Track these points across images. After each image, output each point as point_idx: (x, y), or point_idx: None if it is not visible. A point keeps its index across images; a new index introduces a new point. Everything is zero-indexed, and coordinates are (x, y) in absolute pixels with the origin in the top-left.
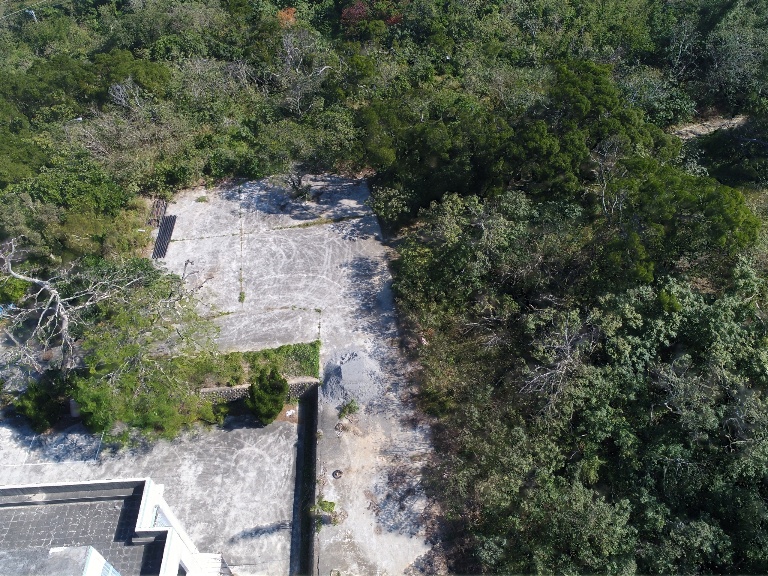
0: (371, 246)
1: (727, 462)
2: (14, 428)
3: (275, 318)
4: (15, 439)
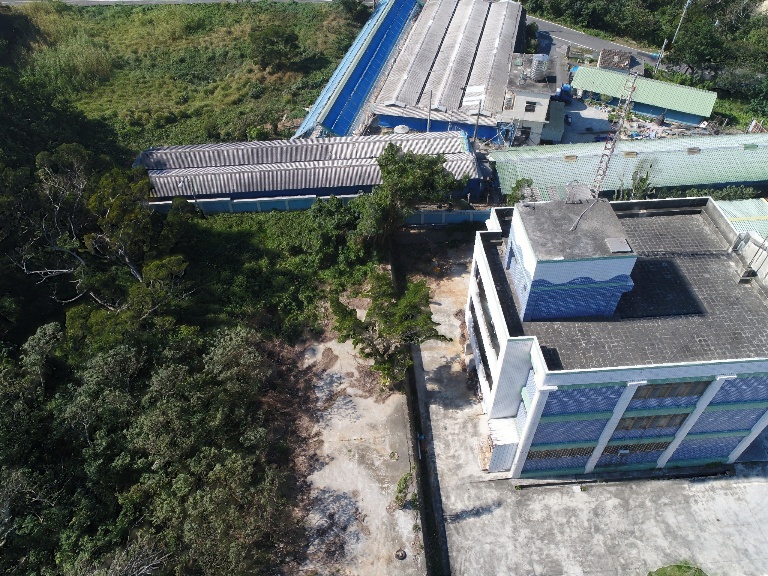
0: None
1: None
2: None
3: None
4: None
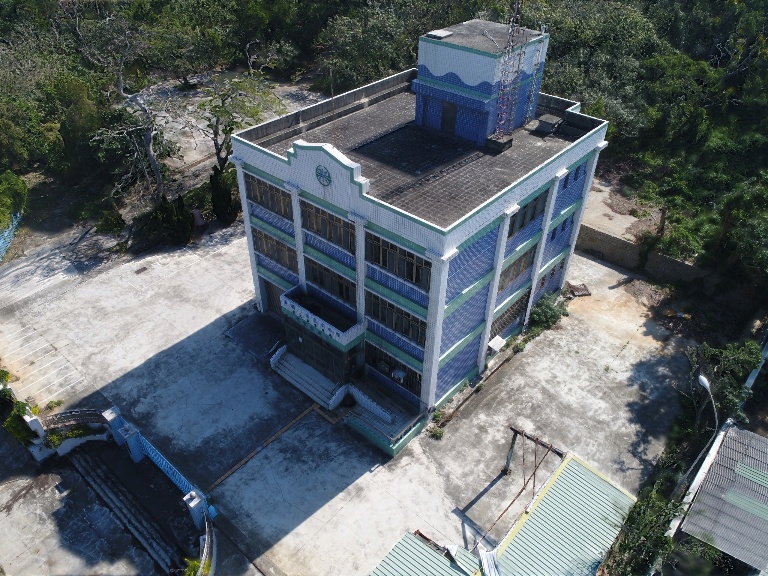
0: (283, 89)
1: (575, 53)
2: (157, 253)
3: None
4: (169, 256)
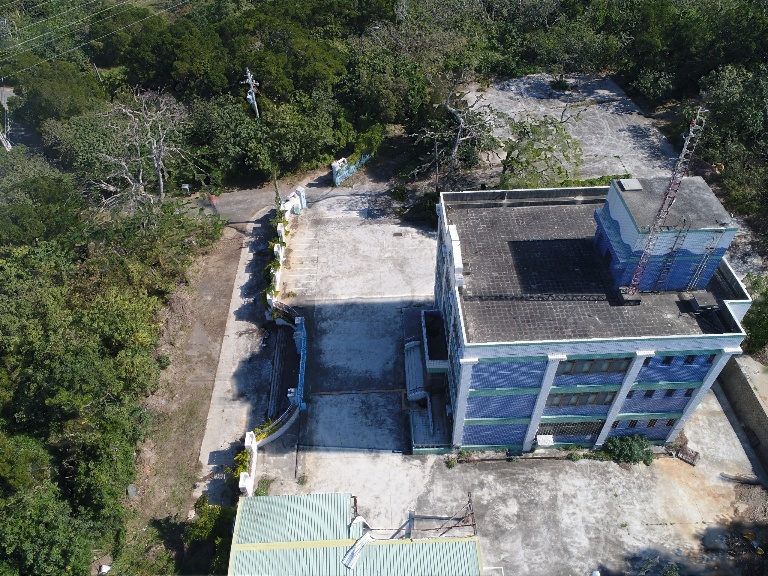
0: (638, 118)
1: None
2: (416, 227)
3: (585, 161)
4: (422, 233)
